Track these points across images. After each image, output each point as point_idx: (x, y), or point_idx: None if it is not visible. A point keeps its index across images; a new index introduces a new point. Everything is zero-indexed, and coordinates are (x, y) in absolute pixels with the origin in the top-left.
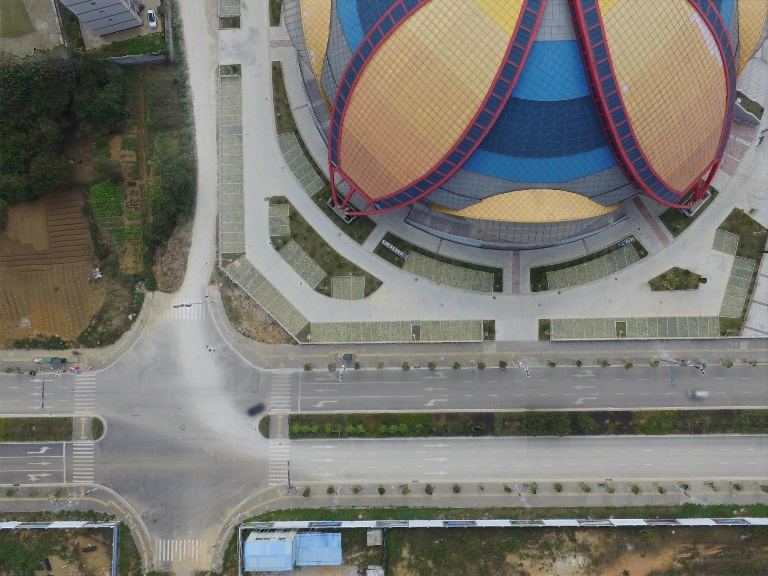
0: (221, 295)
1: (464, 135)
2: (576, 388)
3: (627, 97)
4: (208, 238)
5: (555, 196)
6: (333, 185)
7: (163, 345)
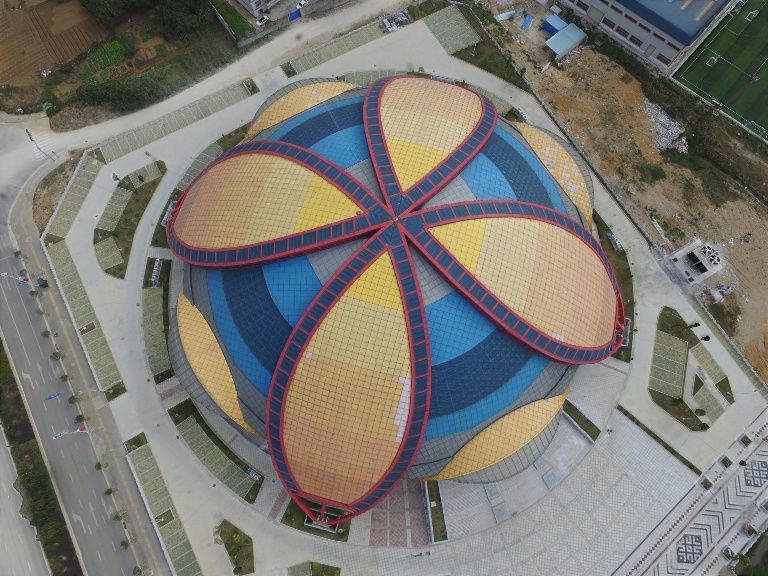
0: (63, 163)
1: (217, 250)
2: (89, 507)
3: (305, 362)
4: (109, 133)
5: (220, 363)
6: (183, 195)
7: (4, 142)
